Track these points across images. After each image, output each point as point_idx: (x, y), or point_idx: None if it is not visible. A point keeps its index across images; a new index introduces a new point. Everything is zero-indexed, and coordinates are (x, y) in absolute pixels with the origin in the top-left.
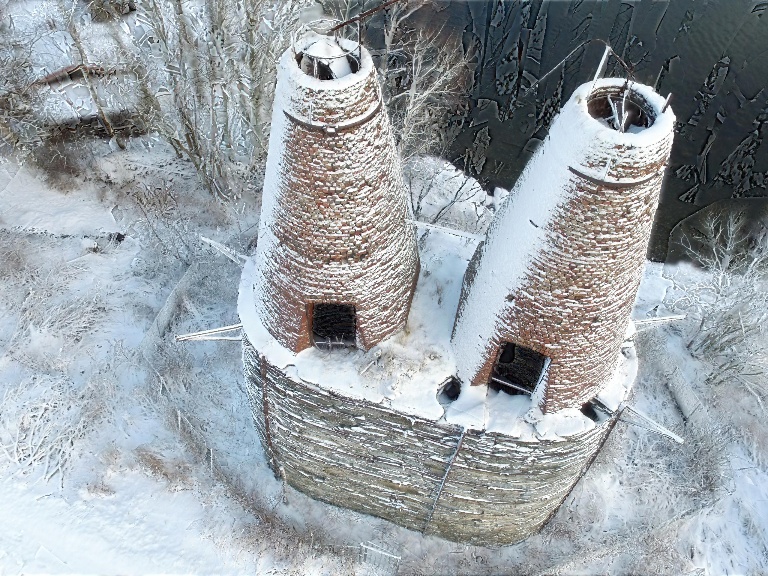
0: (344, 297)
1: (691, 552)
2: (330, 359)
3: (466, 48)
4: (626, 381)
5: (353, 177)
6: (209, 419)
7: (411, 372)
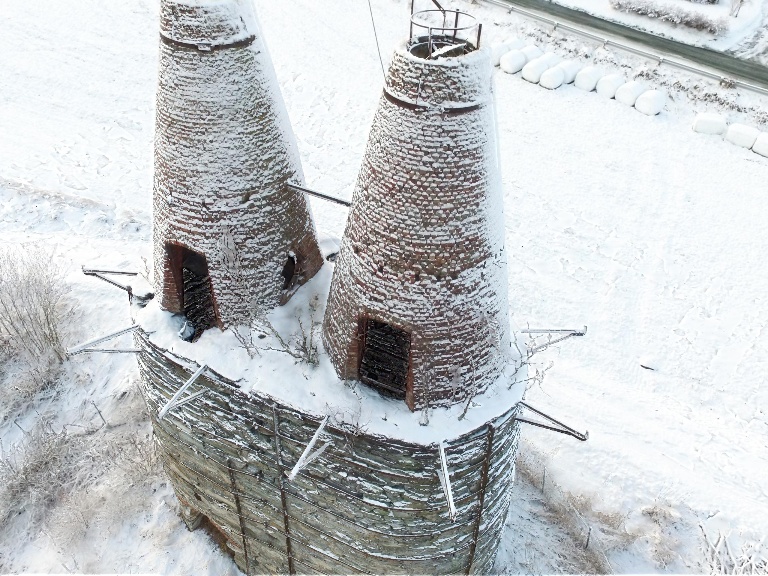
0: None
1: (122, 398)
2: None
3: None
4: None
5: None
6: (560, 573)
7: None
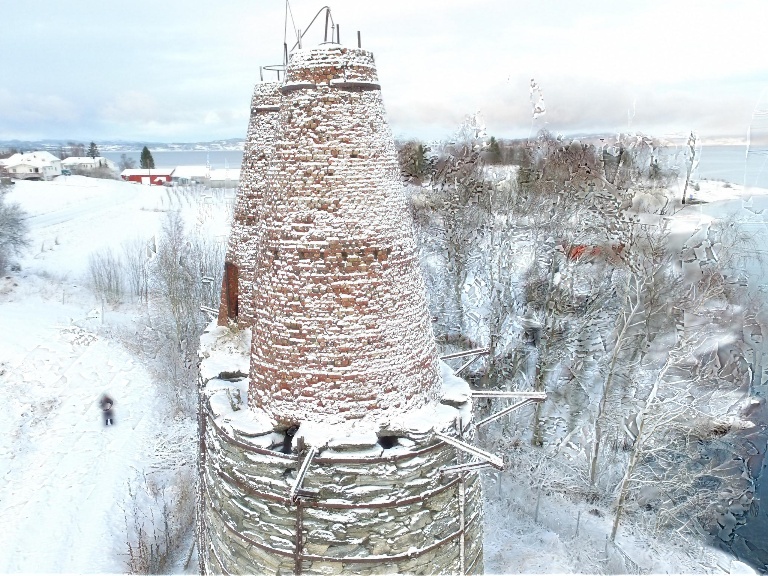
0: (235, 257)
1: None
2: (223, 333)
3: (723, 363)
4: (340, 438)
5: (257, 148)
6: None
7: (236, 350)
